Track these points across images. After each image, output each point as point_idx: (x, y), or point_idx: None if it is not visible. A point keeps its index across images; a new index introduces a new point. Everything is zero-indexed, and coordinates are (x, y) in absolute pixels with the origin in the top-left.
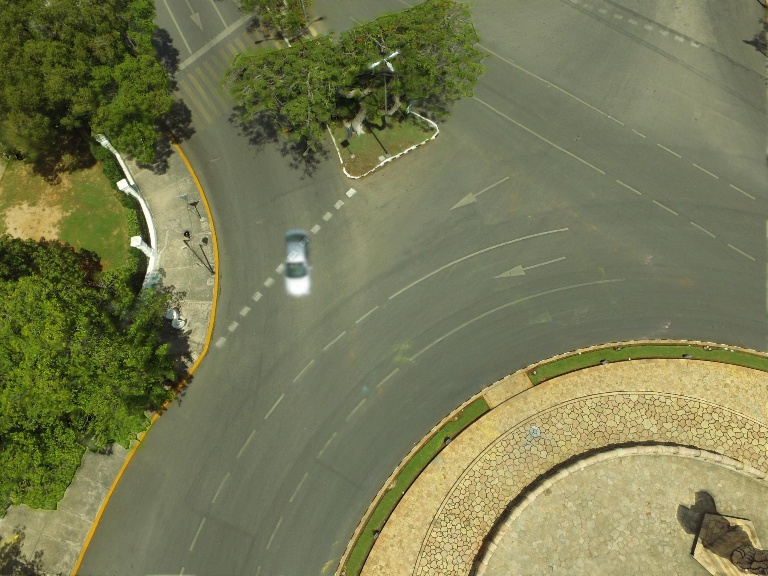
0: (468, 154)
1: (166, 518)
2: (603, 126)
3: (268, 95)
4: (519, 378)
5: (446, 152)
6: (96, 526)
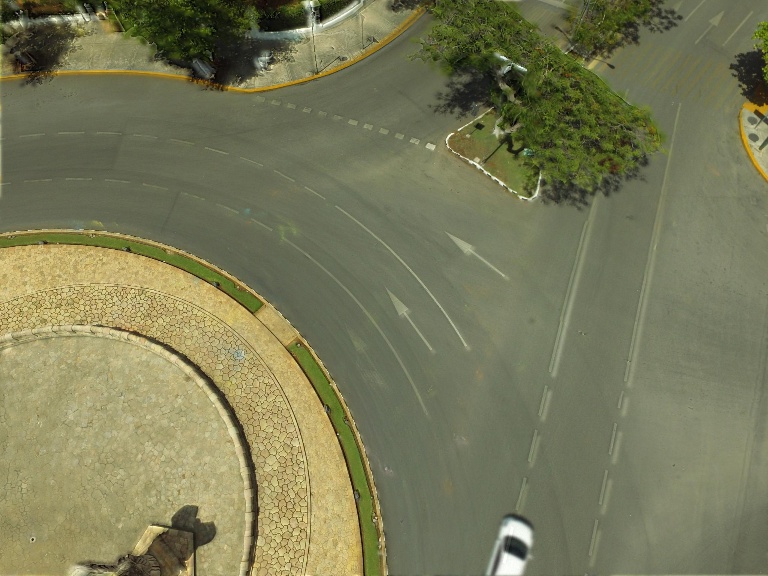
0: (515, 232)
1: (117, 110)
2: (612, 358)
3: (451, 7)
4: (290, 332)
5: (509, 212)
6: (104, 72)
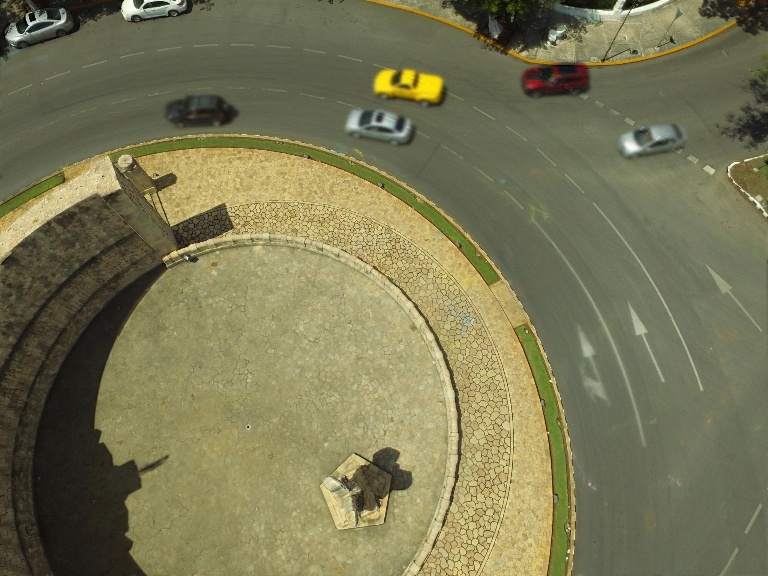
0: None
1: (396, 47)
2: None
3: None
4: (520, 315)
5: None
6: (392, 6)
